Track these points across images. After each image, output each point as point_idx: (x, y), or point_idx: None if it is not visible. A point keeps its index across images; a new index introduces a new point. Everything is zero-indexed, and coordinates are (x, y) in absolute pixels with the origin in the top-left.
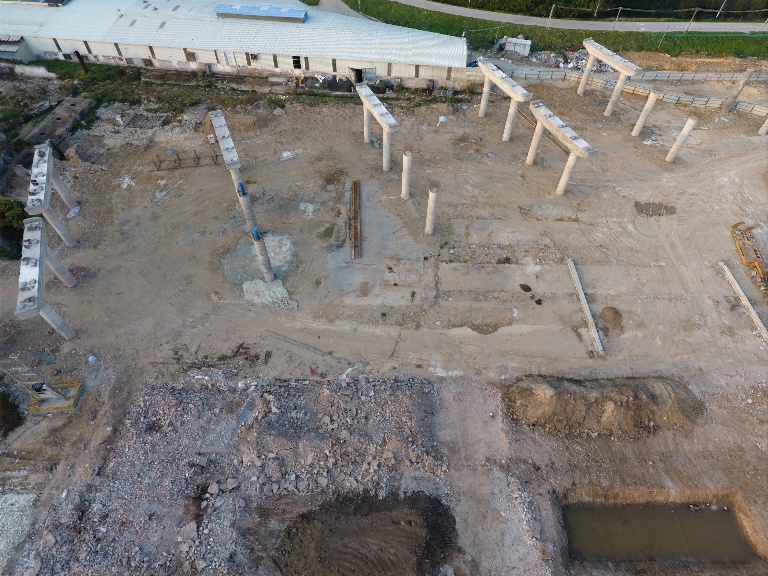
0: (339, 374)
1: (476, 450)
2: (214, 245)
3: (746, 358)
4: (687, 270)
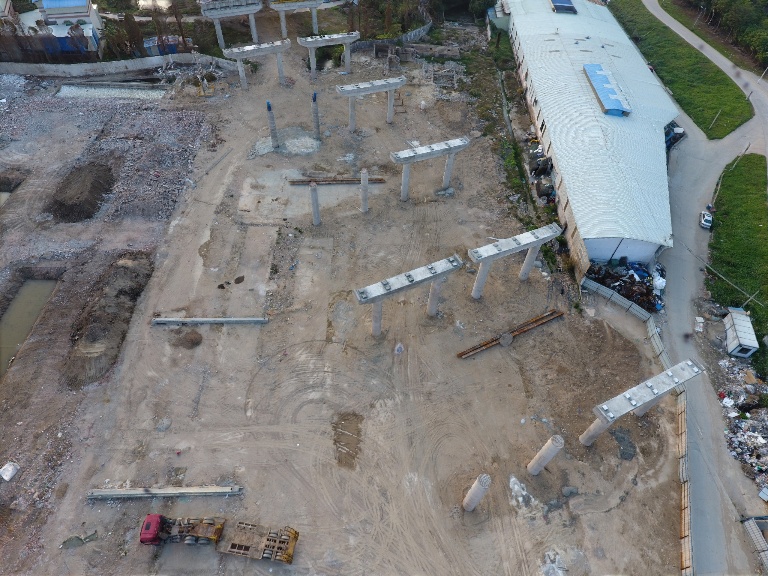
0: (190, 178)
1: (110, 235)
2: (310, 122)
3: (103, 454)
4: (235, 438)
